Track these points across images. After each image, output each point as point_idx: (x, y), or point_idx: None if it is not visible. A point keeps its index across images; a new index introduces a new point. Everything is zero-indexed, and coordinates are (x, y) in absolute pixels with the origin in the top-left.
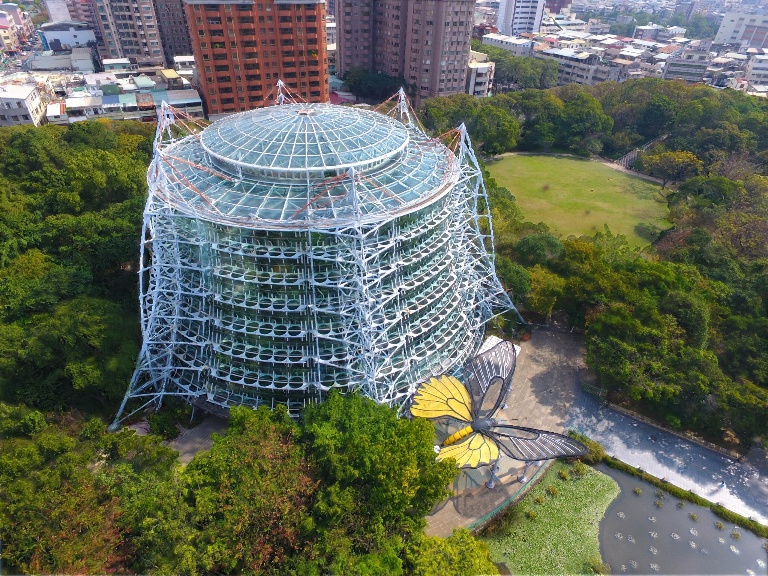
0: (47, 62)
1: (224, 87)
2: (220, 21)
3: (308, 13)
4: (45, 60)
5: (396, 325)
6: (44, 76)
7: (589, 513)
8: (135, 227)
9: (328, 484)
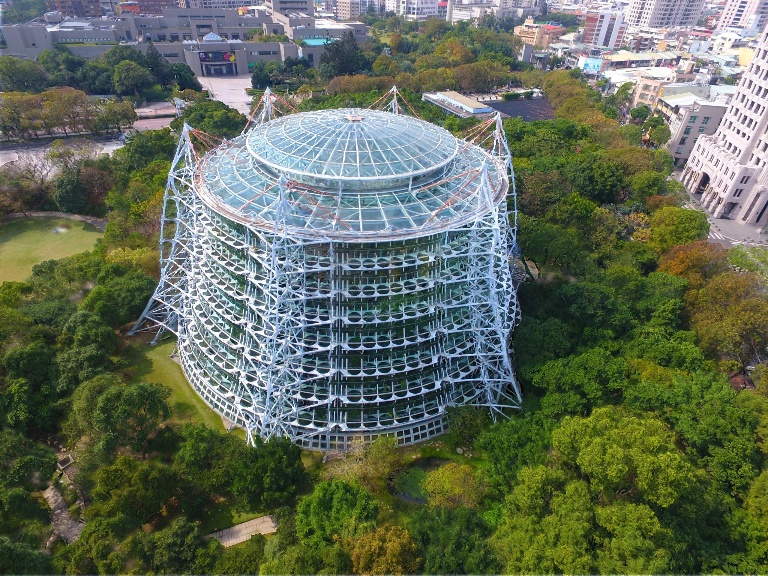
0: None
1: None
2: None
3: None
4: None
5: None
6: None
7: None
8: (534, 415)
9: None
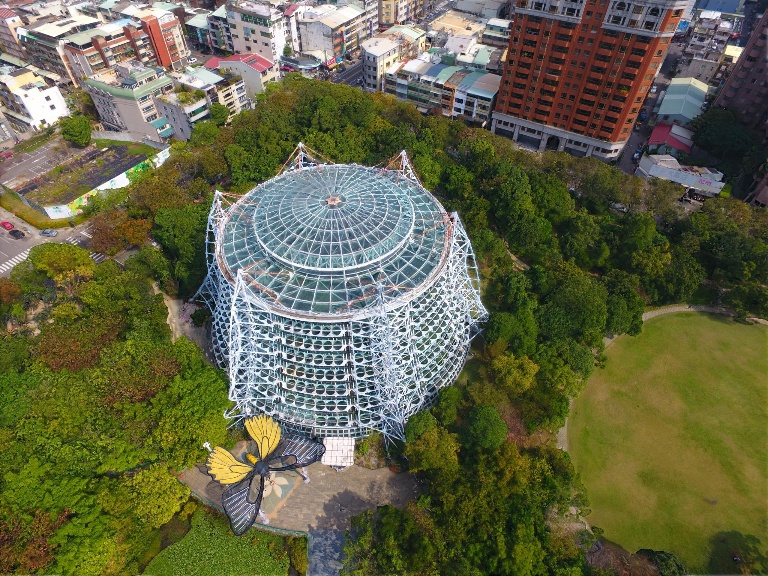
0: (468, 4)
1: (516, 93)
2: (538, 33)
3: (638, 45)
4: (468, 2)
5: (277, 371)
6: (422, 32)
7: (248, 573)
8: None
9: (150, 403)
